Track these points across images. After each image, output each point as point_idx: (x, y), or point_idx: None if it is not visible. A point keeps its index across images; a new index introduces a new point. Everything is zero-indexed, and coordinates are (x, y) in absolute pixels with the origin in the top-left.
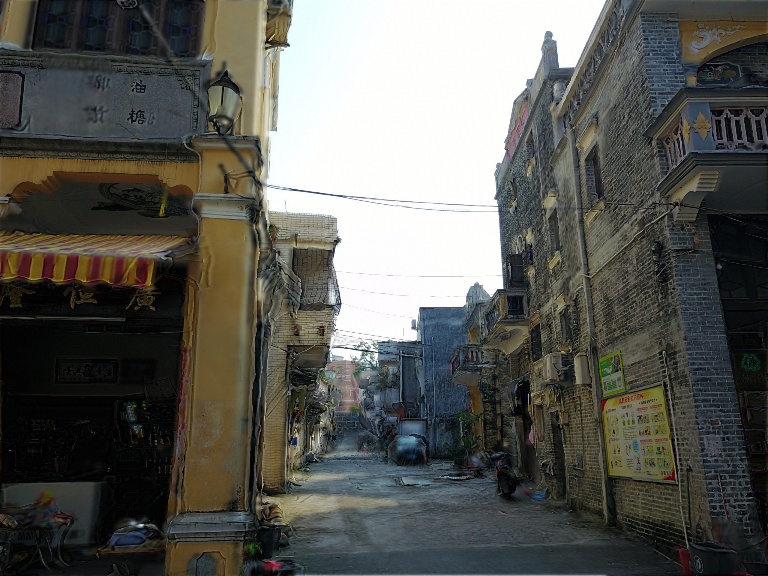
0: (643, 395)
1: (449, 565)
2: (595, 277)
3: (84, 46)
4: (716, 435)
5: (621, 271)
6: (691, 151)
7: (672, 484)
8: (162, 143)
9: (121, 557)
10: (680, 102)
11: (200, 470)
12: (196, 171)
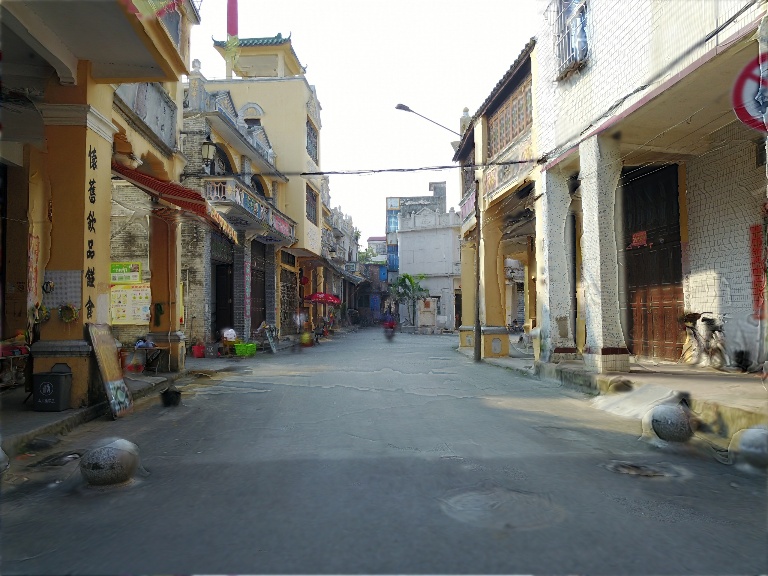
0: None
1: None
2: (116, 217)
3: None
4: (207, 305)
5: None
6: (231, 199)
7: None
8: None
9: None
10: (230, 178)
11: None
12: (171, 166)
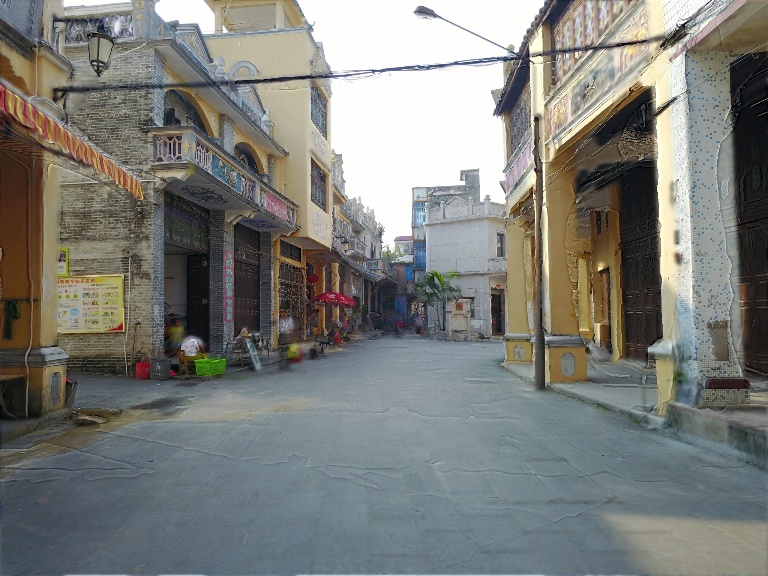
0: (95, 280)
1: None
2: None
3: None
4: None
5: (84, 196)
6: (188, 159)
7: (116, 332)
8: (24, 36)
9: (10, 382)
10: (187, 129)
11: (46, 318)
12: (32, 71)
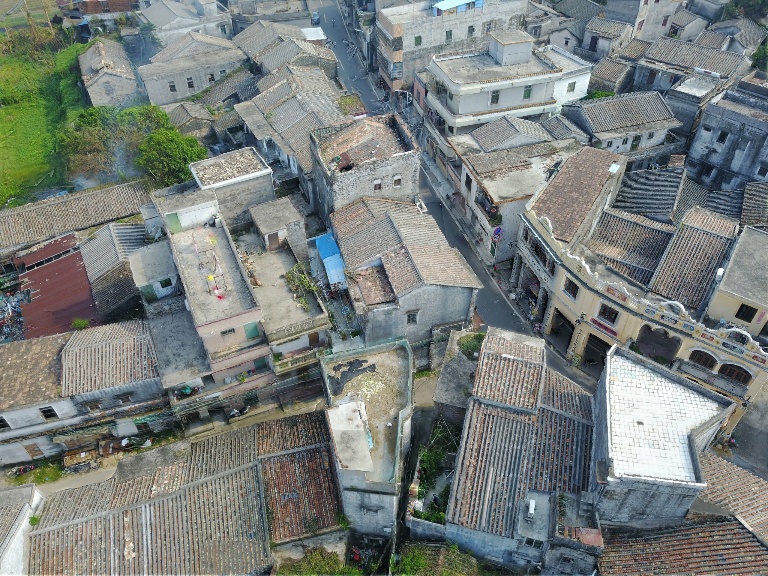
0: None
1: (767, 443)
2: None
3: (727, 375)
4: None
5: None
6: None
7: None
8: None
9: None
10: None
11: None
12: None
